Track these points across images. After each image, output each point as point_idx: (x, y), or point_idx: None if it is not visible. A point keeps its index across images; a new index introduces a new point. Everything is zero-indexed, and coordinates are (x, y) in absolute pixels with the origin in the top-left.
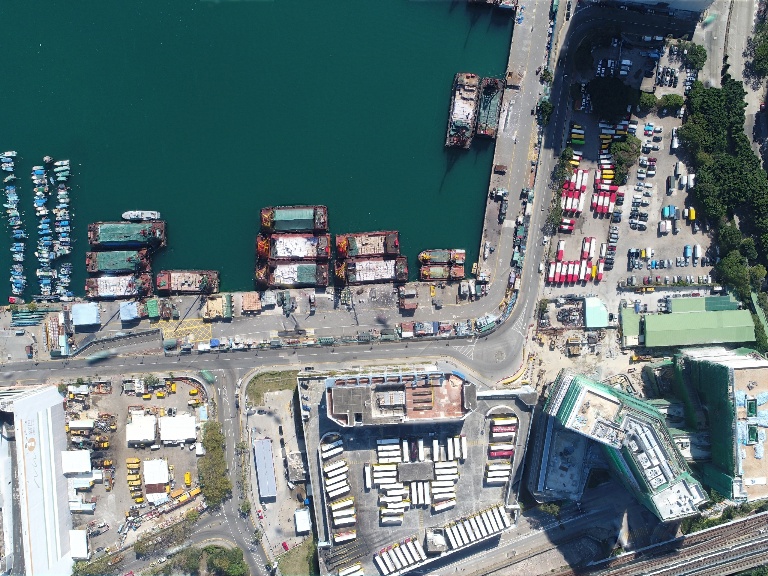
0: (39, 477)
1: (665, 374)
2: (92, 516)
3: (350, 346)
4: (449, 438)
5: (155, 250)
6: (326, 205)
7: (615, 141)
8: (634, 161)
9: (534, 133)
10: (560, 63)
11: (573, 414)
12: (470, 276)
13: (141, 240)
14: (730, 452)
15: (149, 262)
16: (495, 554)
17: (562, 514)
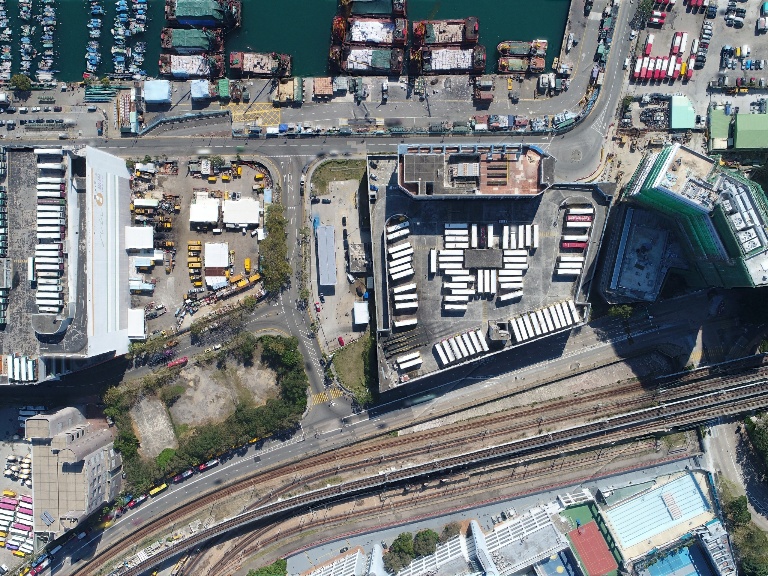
0: (104, 236)
1: (755, 174)
2: (151, 298)
3: (420, 138)
4: (520, 225)
5: (229, 31)
6: None
7: None
8: None
9: None
10: None
11: (662, 172)
12: (550, 71)
13: (217, 17)
14: None
15: (223, 42)
16: (558, 365)
17: (632, 327)
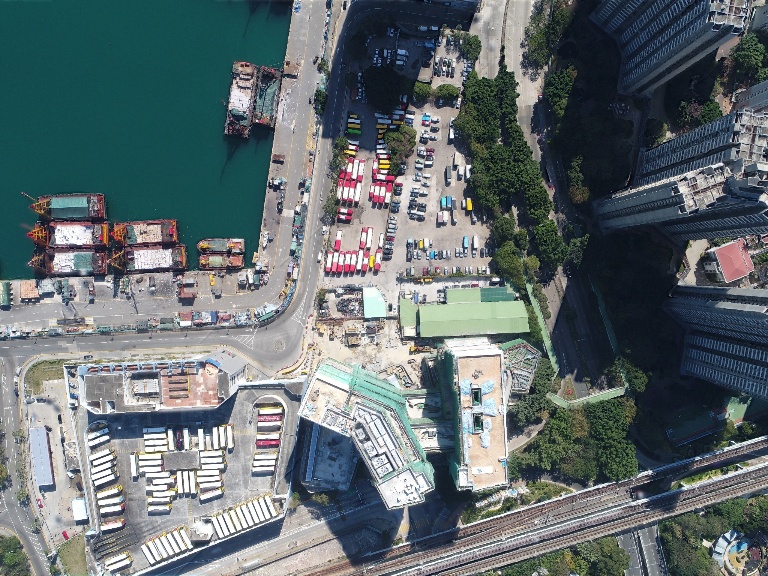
0: None
1: (436, 364)
2: None
3: (129, 335)
4: (214, 427)
5: None
6: (104, 193)
7: (388, 131)
8: (407, 151)
9: (312, 122)
10: (338, 52)
11: (304, 402)
12: (250, 265)
13: None
14: (458, 441)
15: None
16: (277, 544)
17: (343, 505)
